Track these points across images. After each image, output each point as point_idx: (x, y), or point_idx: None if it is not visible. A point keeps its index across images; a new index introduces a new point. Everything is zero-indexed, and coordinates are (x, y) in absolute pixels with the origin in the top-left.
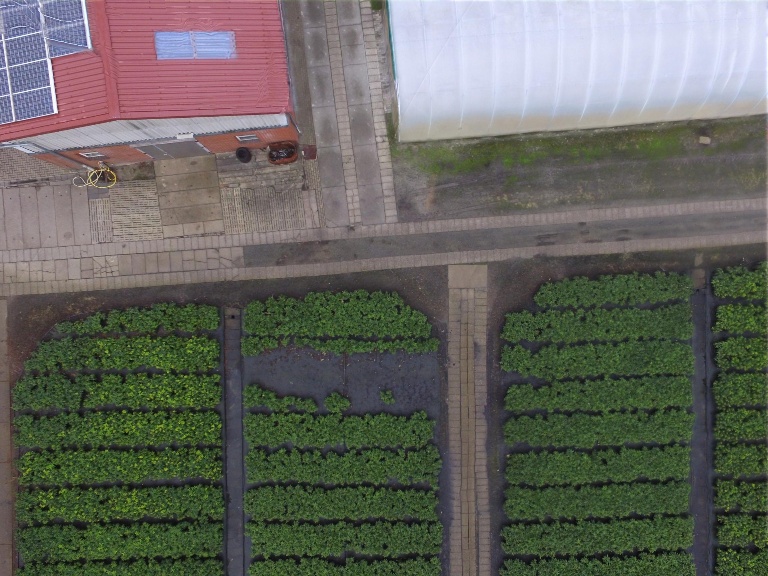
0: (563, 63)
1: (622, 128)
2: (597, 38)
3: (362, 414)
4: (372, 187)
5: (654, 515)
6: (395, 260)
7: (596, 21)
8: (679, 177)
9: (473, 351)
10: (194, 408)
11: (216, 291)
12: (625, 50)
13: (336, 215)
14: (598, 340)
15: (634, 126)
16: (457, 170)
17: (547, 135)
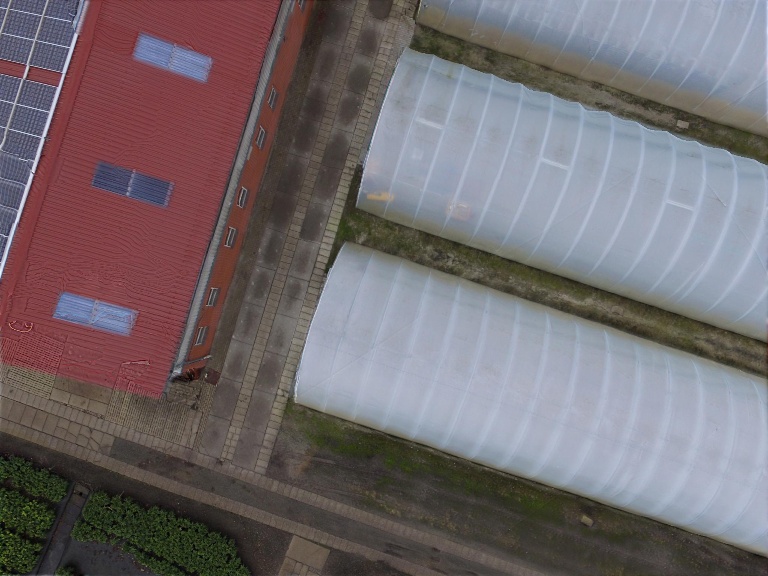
0: (461, 419)
1: (512, 476)
2: (500, 413)
3: None
4: (255, 433)
5: None
6: (247, 509)
7: (505, 398)
8: (547, 546)
9: None
10: (6, 566)
11: (74, 466)
12: (524, 433)
13: (211, 444)
14: None
15: (524, 479)
16: (340, 450)
17: (438, 453)
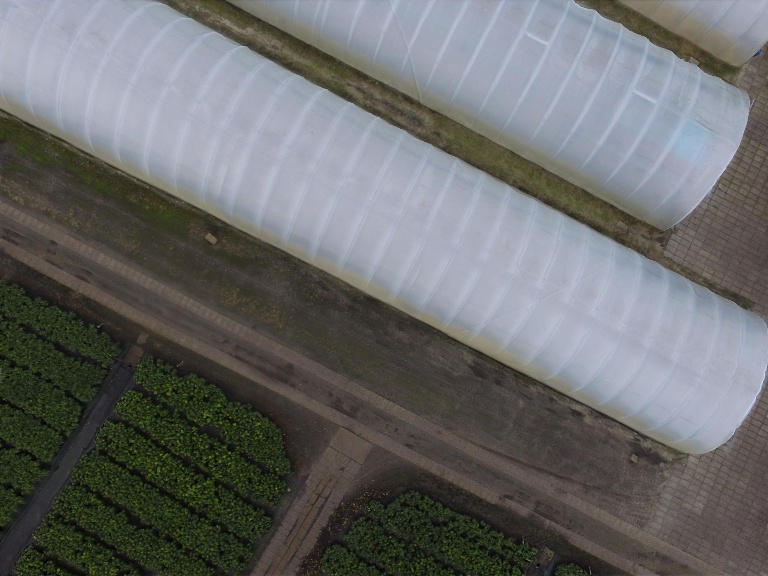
0: (64, 84)
1: (144, 184)
2: (100, 79)
3: None
4: None
5: None
6: None
7: (106, 64)
8: (167, 256)
9: None
10: None
11: None
12: (124, 105)
13: None
14: None
15: (155, 188)
16: None
17: (73, 149)
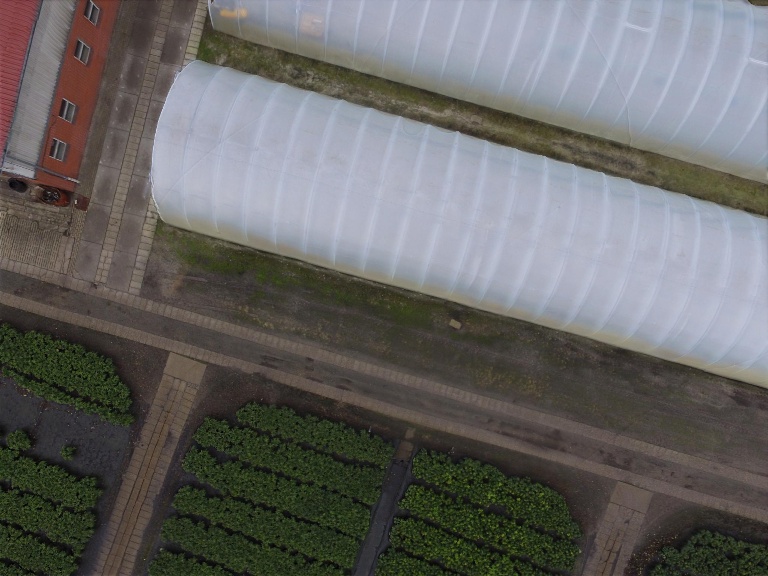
0: (312, 212)
1: (380, 285)
2: (348, 201)
3: (40, 459)
4: (127, 255)
5: None
6: (123, 329)
7: (352, 185)
8: (418, 350)
9: (165, 440)
10: None
11: None
12: (373, 221)
13: (85, 269)
14: (283, 474)
15: (392, 287)
16: (211, 268)
17: (307, 266)
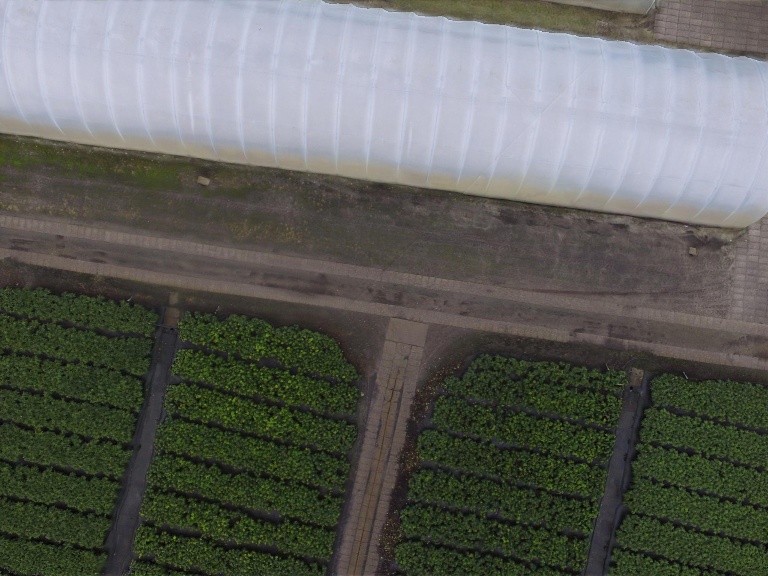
0: (10, 70)
1: (121, 151)
2: (41, 52)
3: None
4: None
5: (63, 543)
6: None
7: (42, 35)
8: (167, 211)
9: None
10: None
11: None
12: (72, 70)
13: None
14: (46, 355)
15: (133, 151)
16: None
17: (44, 142)
